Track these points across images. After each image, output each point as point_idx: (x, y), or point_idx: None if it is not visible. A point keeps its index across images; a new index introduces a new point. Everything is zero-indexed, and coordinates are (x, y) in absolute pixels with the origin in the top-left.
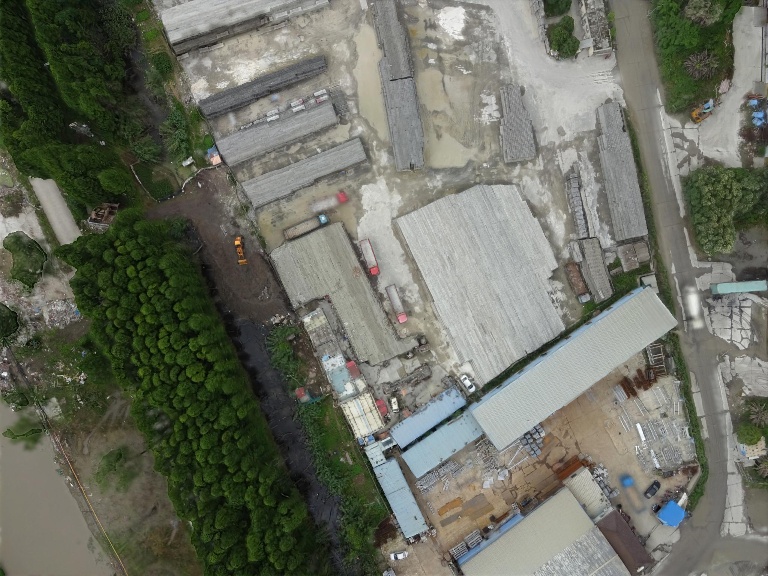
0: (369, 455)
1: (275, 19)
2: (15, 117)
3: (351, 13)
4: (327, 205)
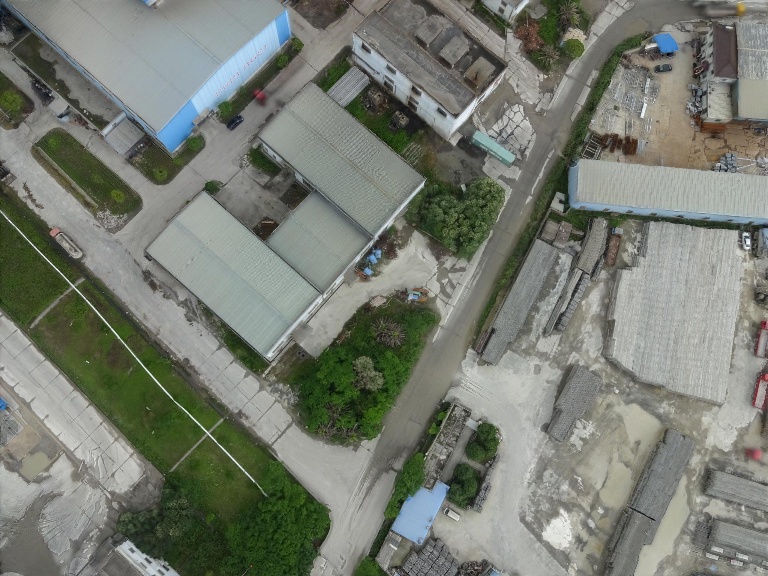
0: None
1: None
2: None
3: None
4: (765, 458)
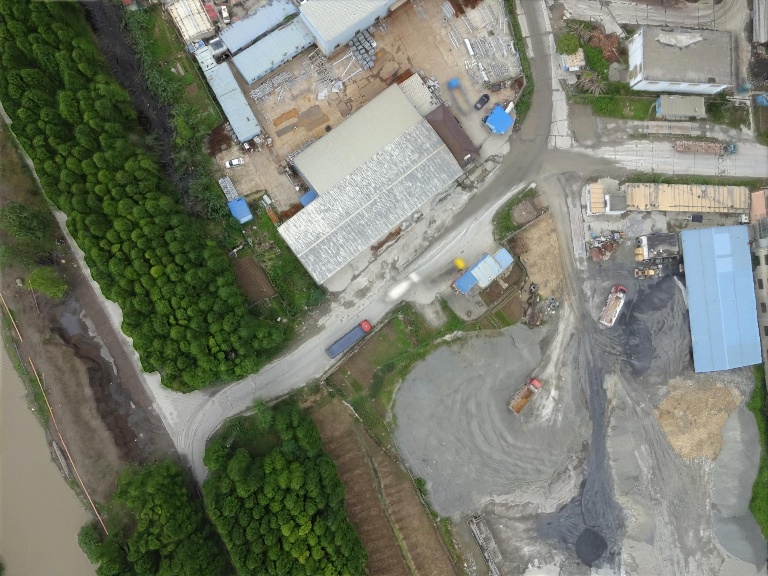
0: (199, 59)
1: None
2: None
3: None
4: None
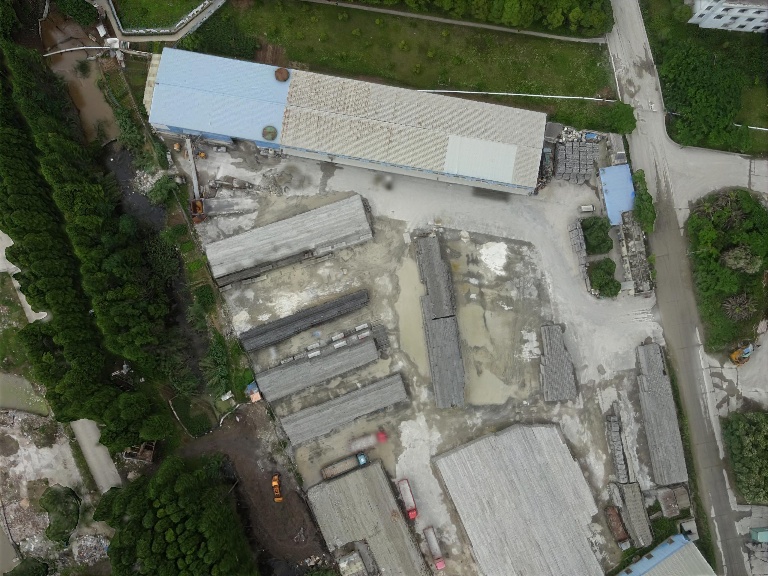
0: None
1: (319, 253)
2: (58, 368)
3: (394, 247)
4: (366, 442)
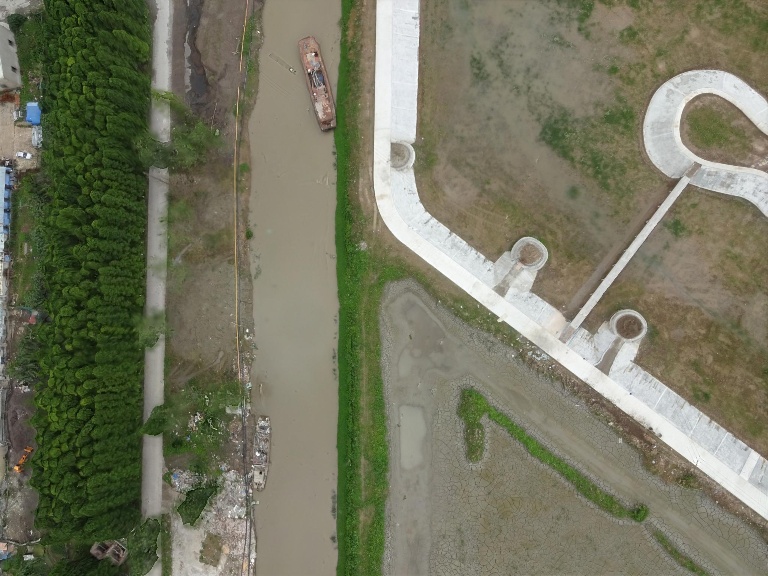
0: (3, 245)
1: None
2: None
3: None
4: None
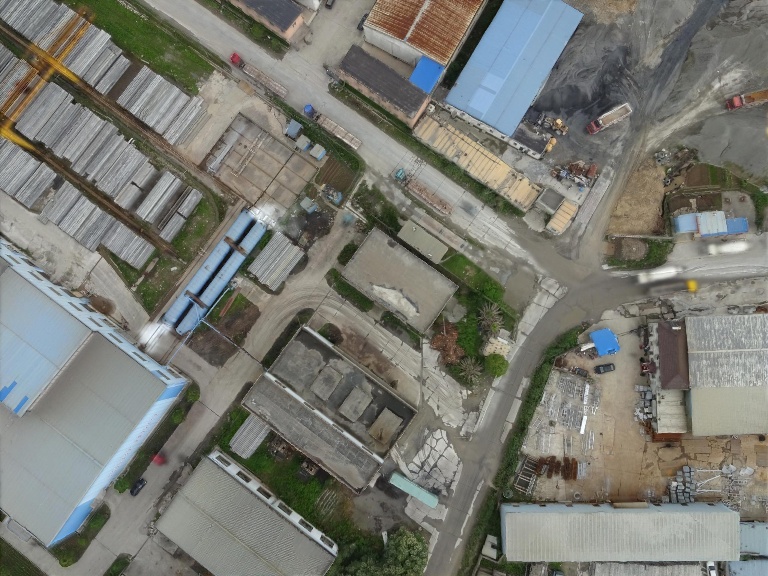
0: None
1: None
2: None
3: None
4: None
